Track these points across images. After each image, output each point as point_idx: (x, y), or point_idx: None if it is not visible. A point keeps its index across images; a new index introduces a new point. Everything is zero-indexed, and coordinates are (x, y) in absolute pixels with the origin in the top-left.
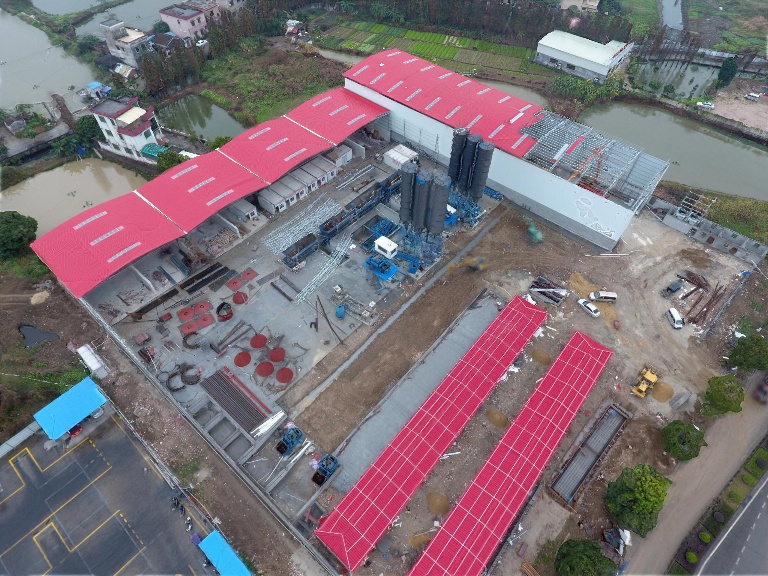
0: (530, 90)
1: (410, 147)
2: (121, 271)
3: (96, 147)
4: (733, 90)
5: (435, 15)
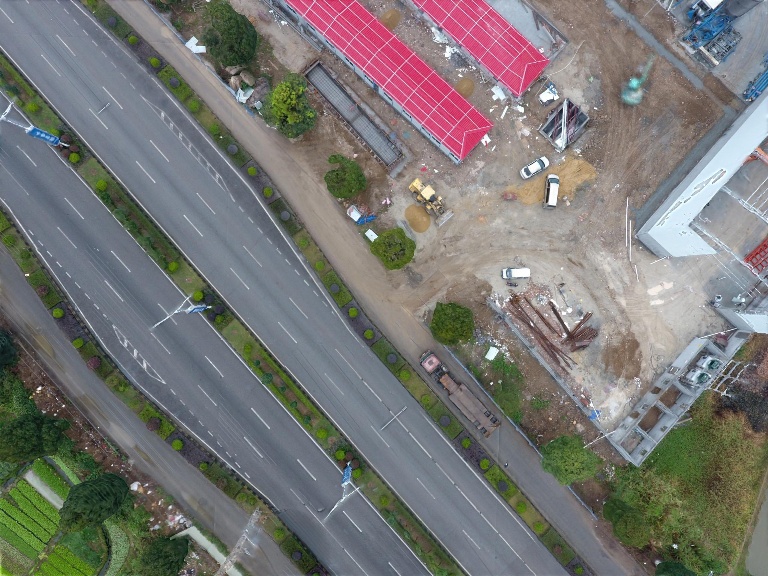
0: None
1: None
2: None
3: None
4: None
5: None
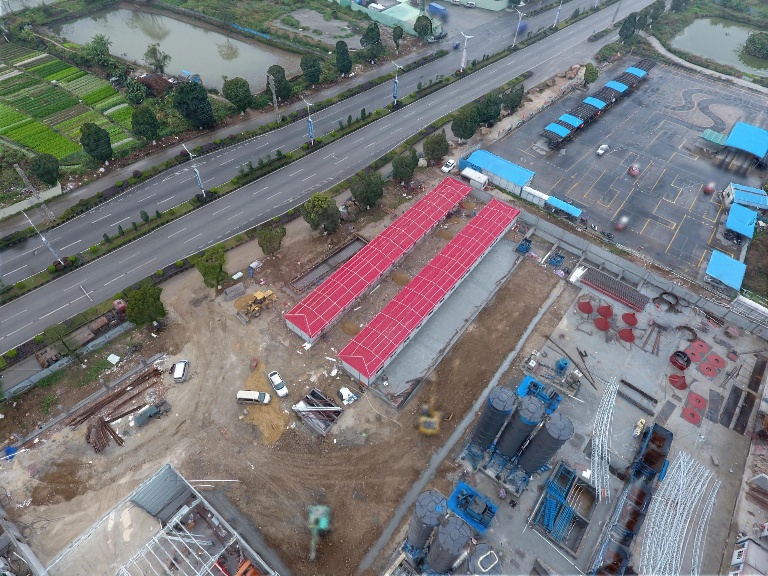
0: None
1: None
2: None
3: None
4: None
5: None
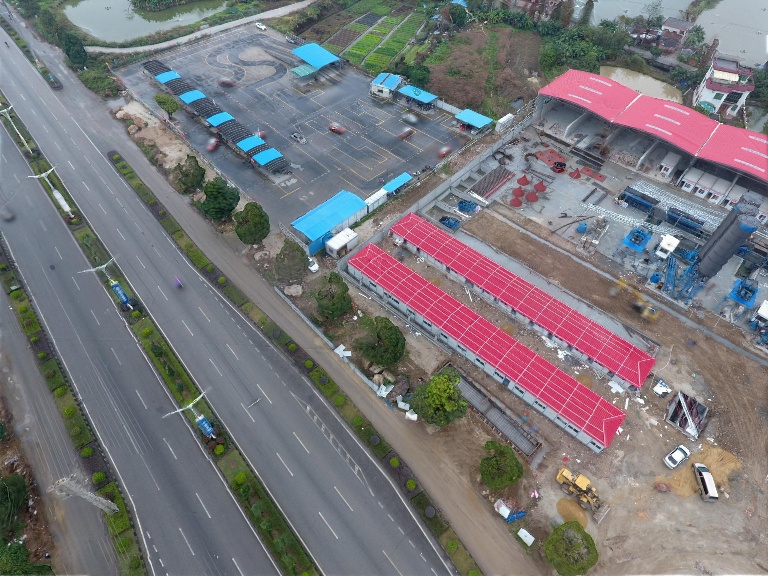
0: None
1: None
2: (565, 103)
3: (693, 88)
4: None
5: None
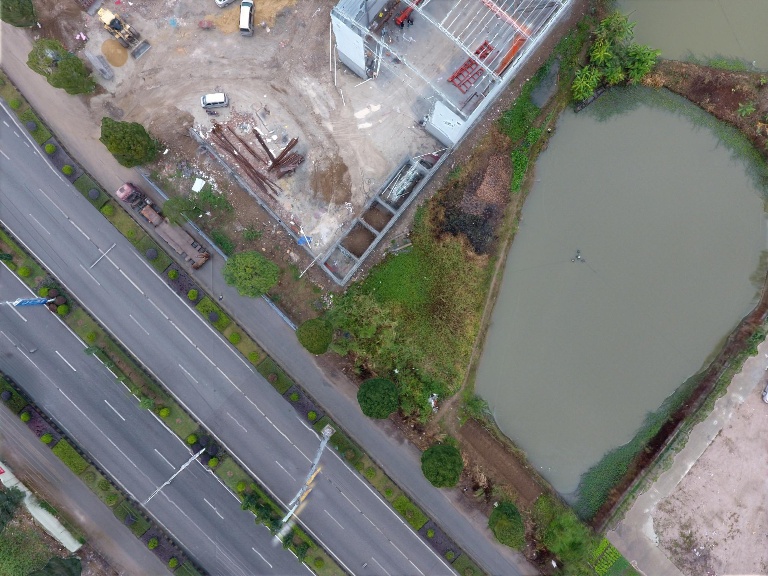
0: None
1: None
2: None
3: None
4: None
5: None
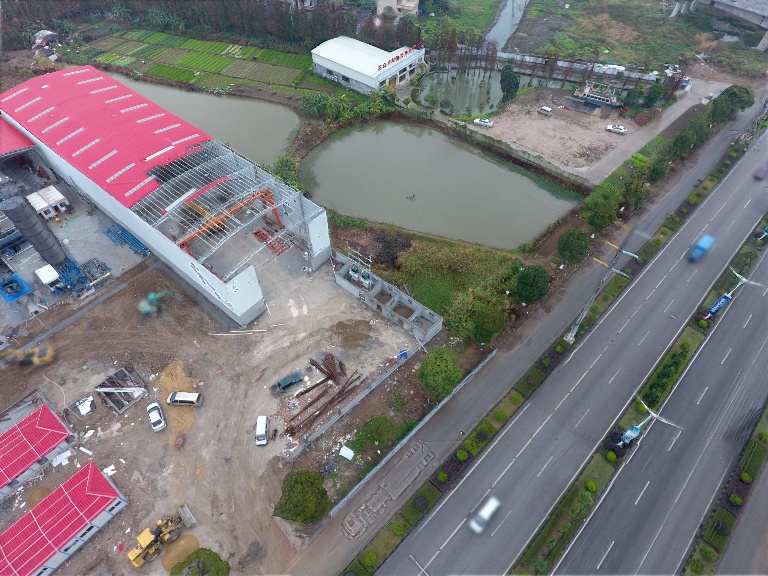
0: (288, 108)
1: (69, 188)
2: None
3: None
4: (529, 102)
5: (217, 21)
